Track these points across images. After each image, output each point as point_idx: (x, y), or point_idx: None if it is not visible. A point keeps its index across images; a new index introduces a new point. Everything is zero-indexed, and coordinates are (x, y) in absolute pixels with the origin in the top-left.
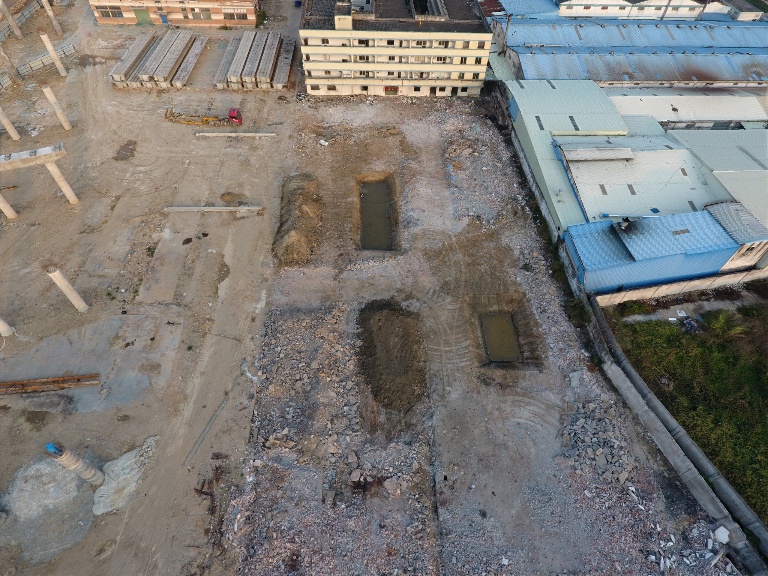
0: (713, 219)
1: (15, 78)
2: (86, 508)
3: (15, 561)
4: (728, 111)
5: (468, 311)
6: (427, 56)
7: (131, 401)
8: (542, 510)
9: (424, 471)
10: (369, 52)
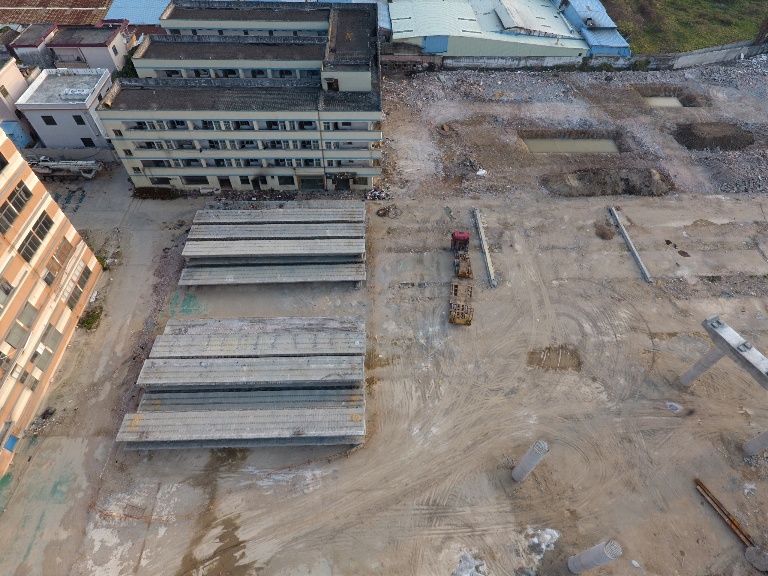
0: None
1: None
2: None
3: None
4: None
5: None
6: None
7: None
8: None
9: None
10: None
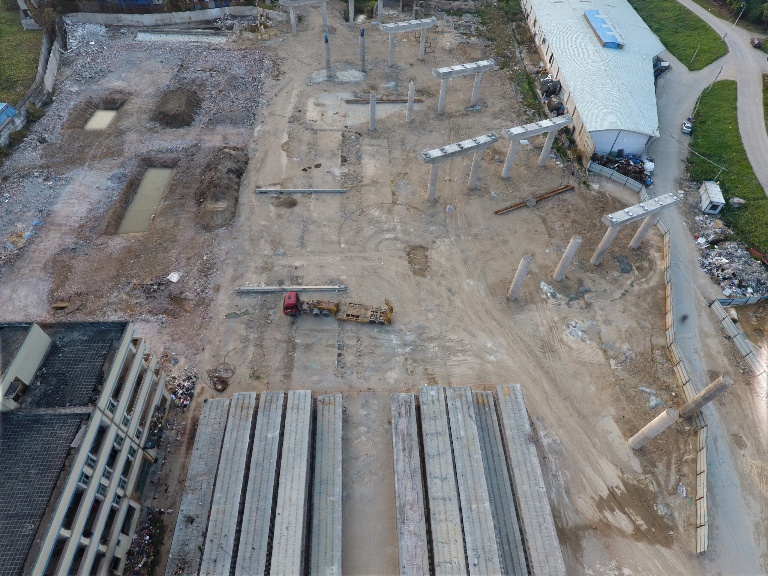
0: None
1: None
2: None
3: (349, 63)
4: None
5: None
6: None
7: (325, 95)
8: None
9: None
10: None
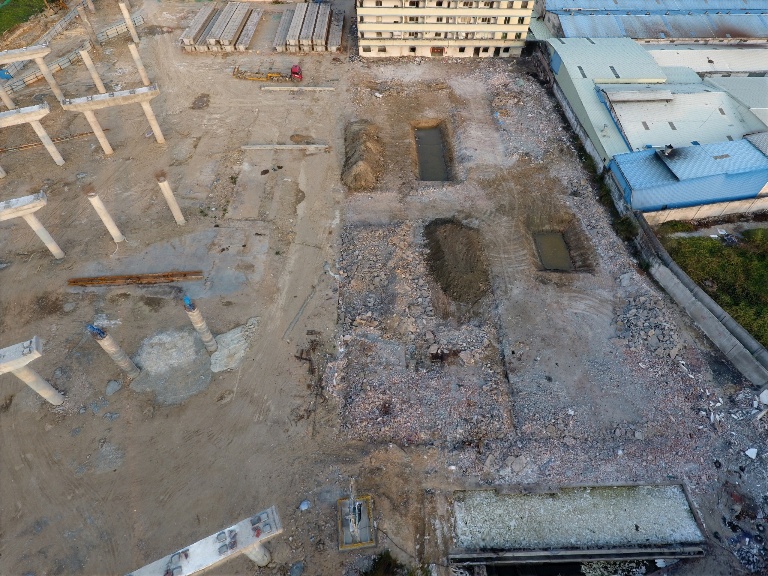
0: (752, 146)
1: (95, 44)
2: (205, 367)
3: (152, 402)
4: (762, 63)
5: (523, 228)
6: (473, 16)
7: (232, 291)
8: (601, 377)
9: (493, 347)
10: (419, 13)
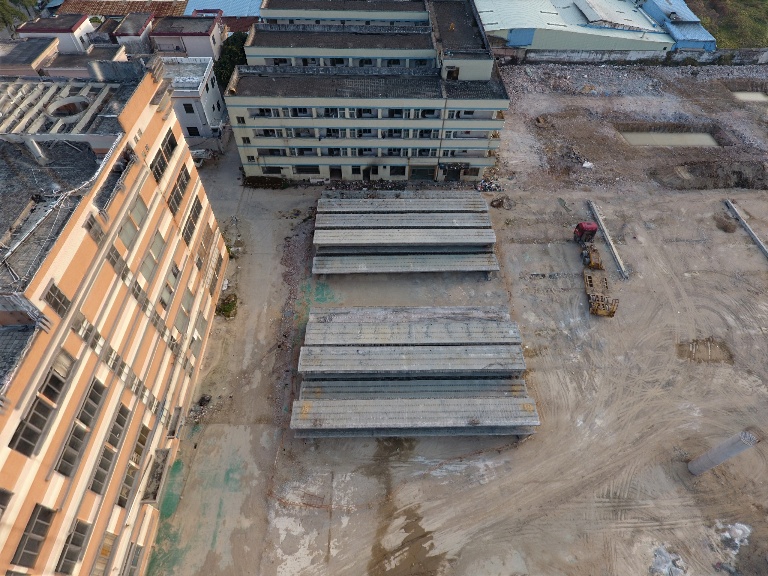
0: None
1: None
2: None
3: None
4: None
5: None
6: None
7: None
8: None
9: None
10: None
